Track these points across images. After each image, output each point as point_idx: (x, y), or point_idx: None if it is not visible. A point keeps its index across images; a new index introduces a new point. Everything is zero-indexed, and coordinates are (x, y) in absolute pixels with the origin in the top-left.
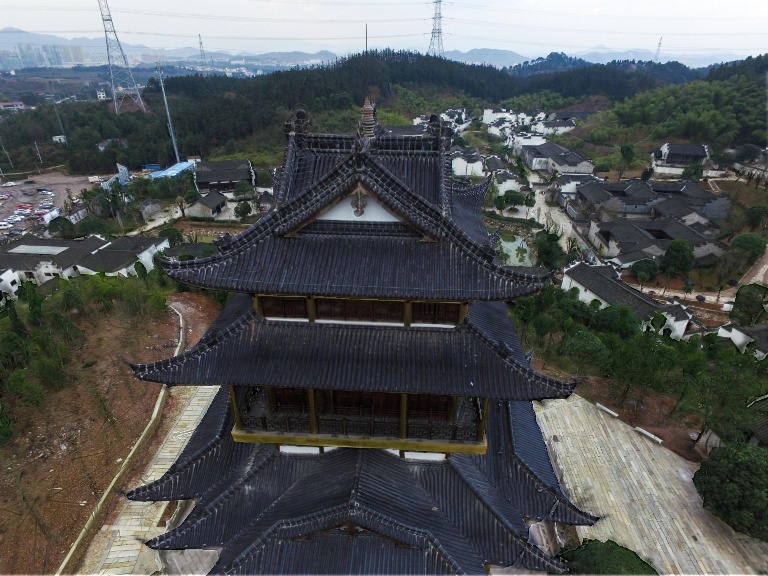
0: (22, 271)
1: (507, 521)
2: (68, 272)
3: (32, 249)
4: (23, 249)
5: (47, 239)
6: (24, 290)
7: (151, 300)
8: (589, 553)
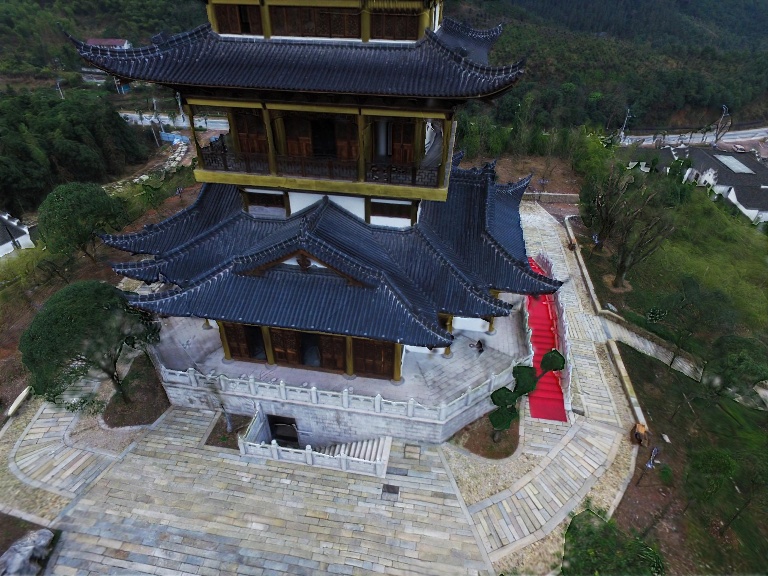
0: (696, 171)
1: (177, 248)
2: (721, 190)
3: (731, 161)
4: (726, 158)
5: (756, 161)
6: (608, 146)
7: (583, 162)
8: (110, 288)
